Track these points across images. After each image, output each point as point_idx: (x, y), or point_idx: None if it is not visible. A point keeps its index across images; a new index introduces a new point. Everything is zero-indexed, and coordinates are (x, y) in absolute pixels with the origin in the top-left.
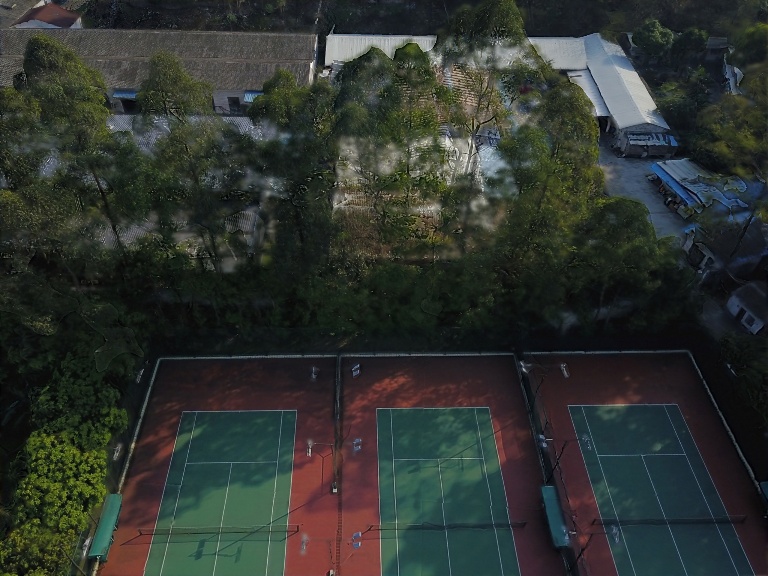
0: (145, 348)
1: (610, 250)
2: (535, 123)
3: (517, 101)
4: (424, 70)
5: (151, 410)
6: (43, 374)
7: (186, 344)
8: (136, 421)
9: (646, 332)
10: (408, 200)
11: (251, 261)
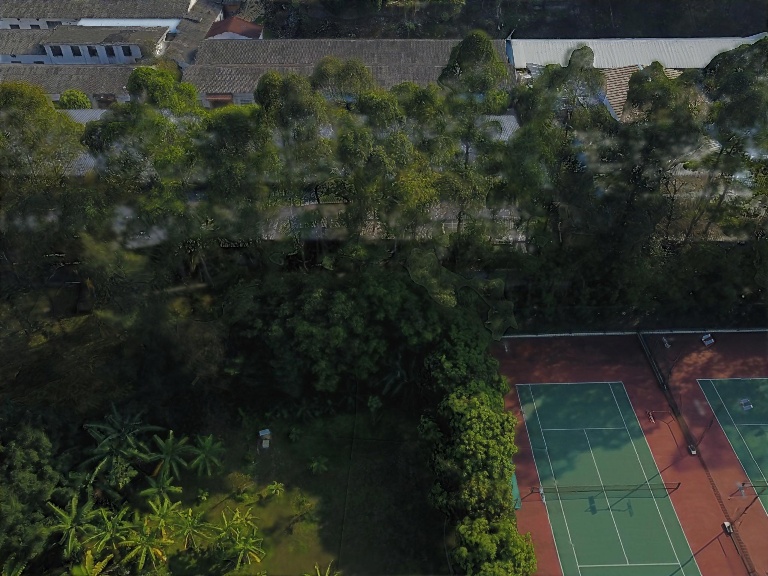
0: None
1: None
2: None
3: None
4: None
5: None
6: (426, 346)
7: None
8: None
9: None
10: (759, 180)
11: None
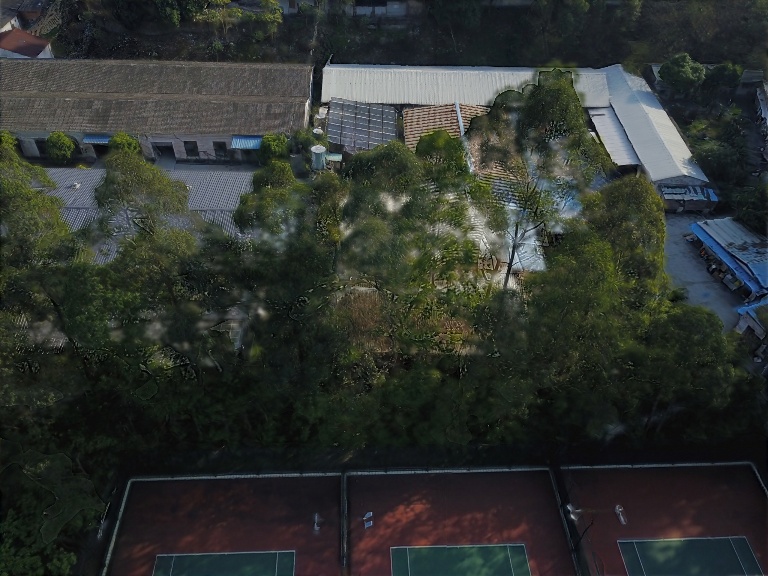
0: (111, 477)
1: (675, 370)
2: (593, 229)
3: (571, 203)
4: (455, 163)
5: (119, 554)
6: None
7: (162, 460)
8: (100, 572)
9: (704, 444)
10: (432, 315)
11: (239, 370)
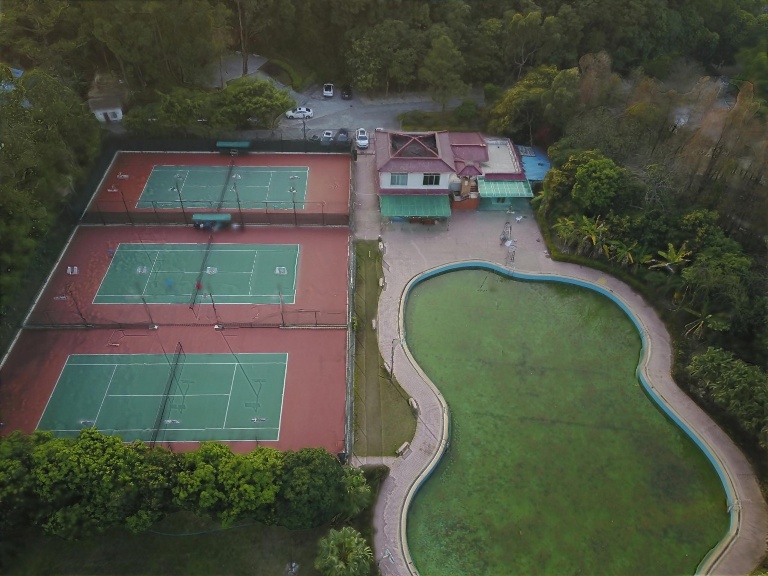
0: None
1: (55, 105)
2: None
3: None
4: None
5: None
6: None
7: None
8: None
9: (98, 156)
10: None
11: None
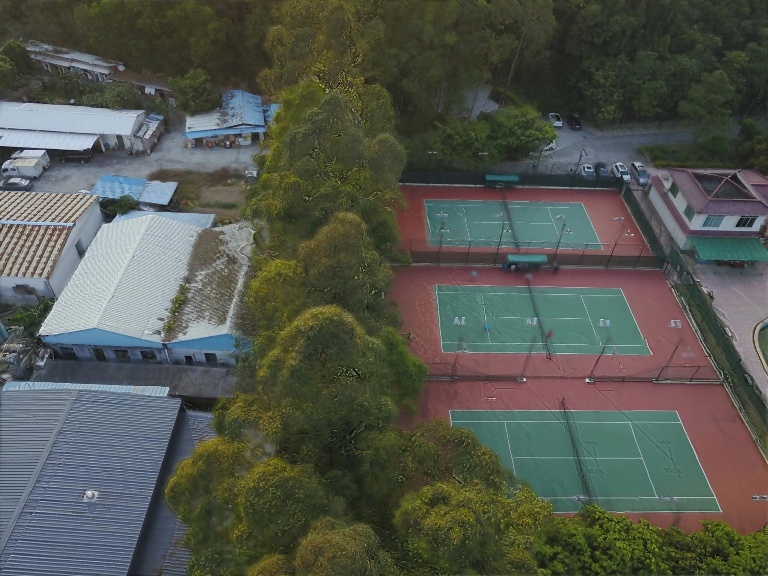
0: None
1: None
2: None
3: None
4: None
5: None
6: None
7: None
8: None
9: None
10: None
11: None
